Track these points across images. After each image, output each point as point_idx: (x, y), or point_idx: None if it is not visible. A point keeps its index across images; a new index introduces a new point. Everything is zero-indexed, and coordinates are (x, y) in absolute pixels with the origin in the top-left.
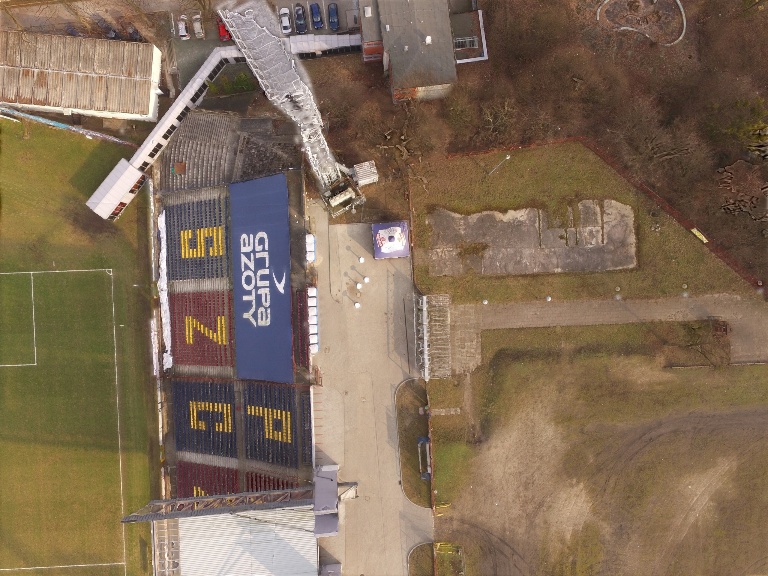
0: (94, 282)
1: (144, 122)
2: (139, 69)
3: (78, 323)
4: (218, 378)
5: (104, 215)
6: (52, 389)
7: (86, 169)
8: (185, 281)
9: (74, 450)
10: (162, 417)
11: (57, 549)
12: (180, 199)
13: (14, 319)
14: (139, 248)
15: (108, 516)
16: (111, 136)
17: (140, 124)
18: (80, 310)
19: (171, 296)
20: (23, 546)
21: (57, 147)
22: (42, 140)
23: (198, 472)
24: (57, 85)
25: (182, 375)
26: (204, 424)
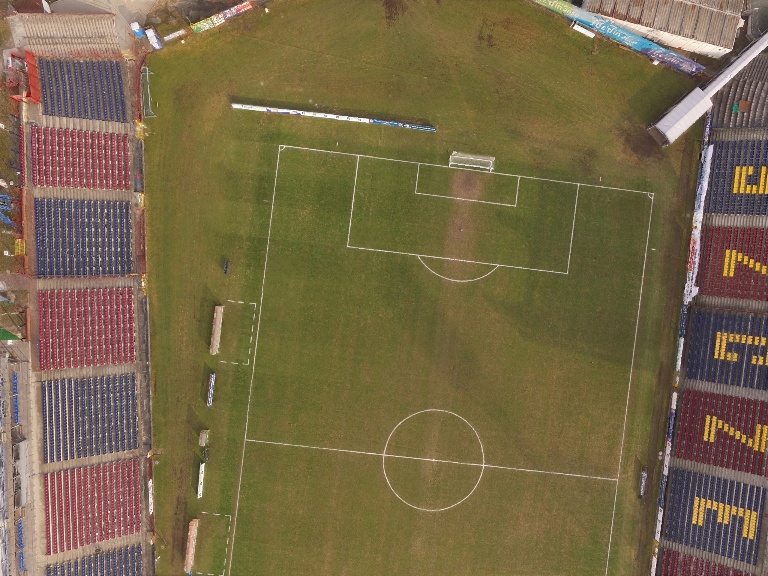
0: (635, 203)
1: (706, 57)
2: (730, 4)
3: (614, 240)
4: (765, 313)
5: (672, 139)
6: (578, 300)
7: (645, 93)
8: (731, 215)
9: (589, 362)
10: (678, 344)
11: (557, 456)
12: (739, 136)
13: (554, 226)
14: (681, 177)
15: (610, 431)
16: (697, 64)
17: (701, 58)
18: (617, 228)
19: (707, 228)
20: (525, 448)
21: (621, 67)
22: (609, 58)
23: (715, 402)
24: (652, 6)
25: (708, 306)
26: (737, 355)
